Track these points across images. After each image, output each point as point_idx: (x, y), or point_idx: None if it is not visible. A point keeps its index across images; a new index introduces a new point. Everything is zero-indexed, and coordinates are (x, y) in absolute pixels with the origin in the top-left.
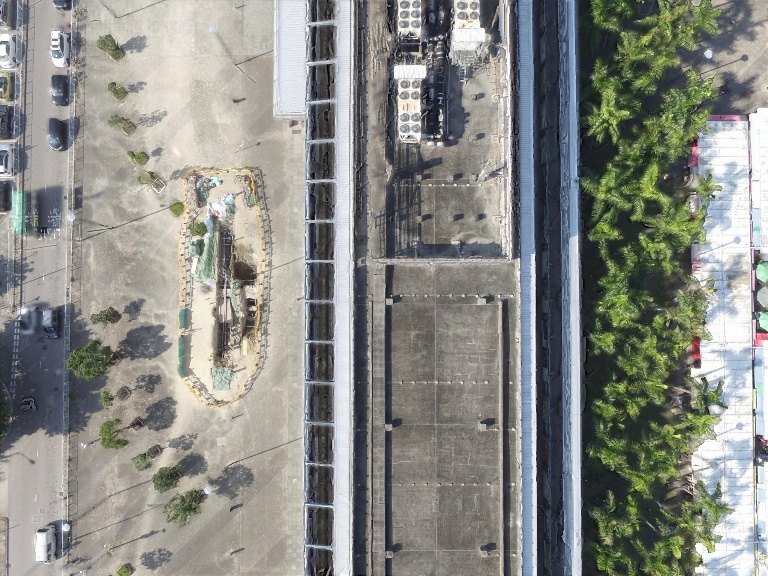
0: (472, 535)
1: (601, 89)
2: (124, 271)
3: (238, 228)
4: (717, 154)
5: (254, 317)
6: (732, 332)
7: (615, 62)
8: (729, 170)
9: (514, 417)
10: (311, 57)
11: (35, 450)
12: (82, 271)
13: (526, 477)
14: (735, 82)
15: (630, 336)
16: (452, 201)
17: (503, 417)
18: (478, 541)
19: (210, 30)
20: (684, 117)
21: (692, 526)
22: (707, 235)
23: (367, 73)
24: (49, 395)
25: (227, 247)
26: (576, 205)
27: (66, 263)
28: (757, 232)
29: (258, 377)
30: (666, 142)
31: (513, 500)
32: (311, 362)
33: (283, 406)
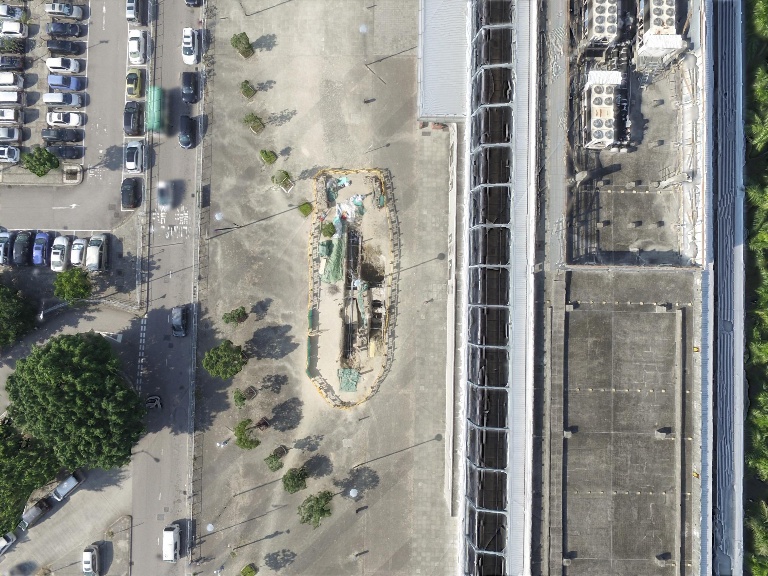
0: (647, 544)
1: (763, 97)
2: (251, 270)
3: (367, 229)
4: None
5: (381, 319)
6: None
7: None
8: None
9: (690, 426)
10: (475, 60)
11: (160, 448)
12: (209, 270)
13: (701, 487)
14: None
15: None
16: (630, 208)
17: (680, 426)
18: (653, 550)
19: (360, 30)
20: None
21: None
22: None
23: (546, 77)
24: (174, 393)
25: (354, 248)
26: (741, 214)
27: (193, 261)
28: None
29: (385, 379)
30: None
31: (688, 510)
32: None
33: (410, 409)
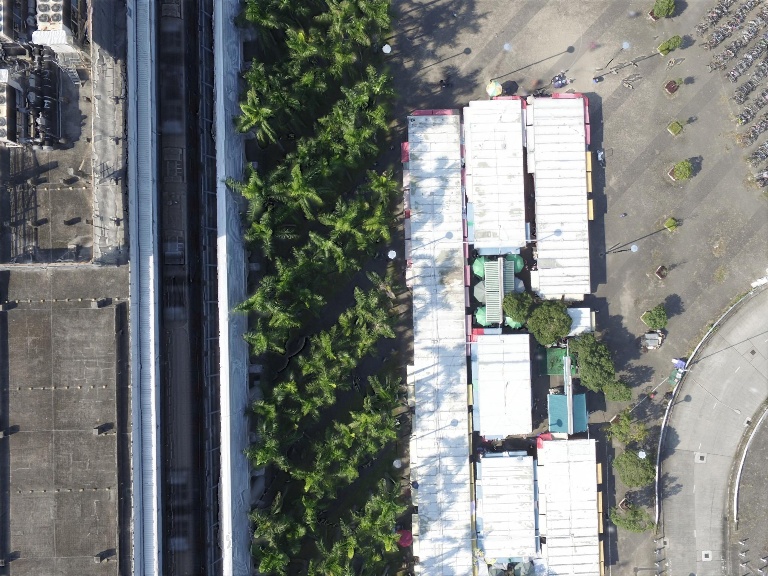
0: (91, 541)
1: None
2: None
3: None
4: (428, 149)
5: None
6: (445, 328)
7: (289, 59)
8: (440, 165)
9: None
10: None
11: None
12: None
13: (147, 481)
14: (458, 76)
15: (314, 335)
16: (69, 205)
17: (121, 421)
18: (97, 547)
19: None
20: (354, 113)
21: (370, 525)
22: (419, 231)
23: None
24: None
25: None
26: (223, 205)
27: None
28: (471, 226)
29: None
30: None
31: None
32: None
33: None
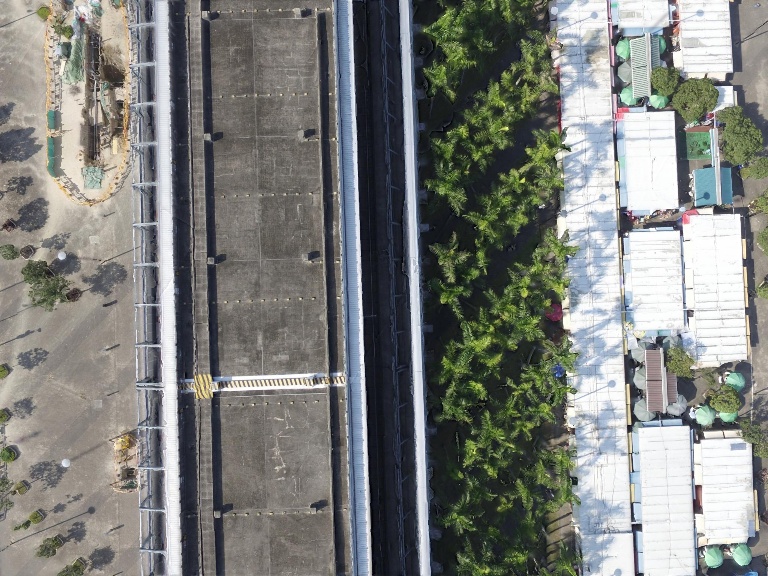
0: (295, 244)
1: None
2: None
3: (105, 30)
4: None
5: None
6: (592, 105)
7: None
8: None
9: (334, 127)
10: None
11: None
12: None
13: (348, 186)
14: None
15: (477, 92)
16: None
17: (323, 127)
18: (301, 249)
19: None
20: None
21: (541, 270)
22: (564, 11)
23: None
24: None
25: (96, 51)
26: None
27: None
28: (615, 8)
29: (129, 175)
30: None
31: (335, 209)
32: (149, 109)
33: None
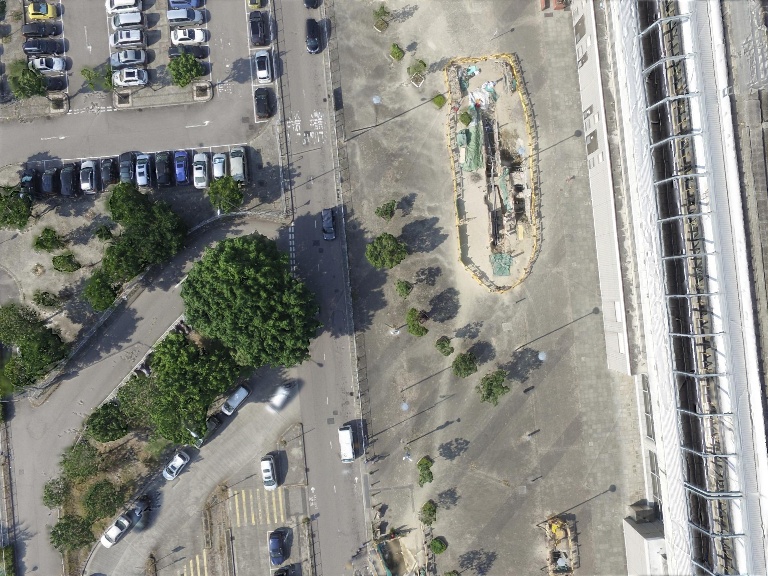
0: None
1: None
2: (392, 167)
3: (501, 115)
4: None
5: (525, 202)
6: None
7: None
8: None
9: None
10: None
11: (322, 353)
12: (350, 171)
13: None
14: None
15: None
16: None
17: None
18: None
19: None
20: None
21: None
22: None
23: None
24: (330, 297)
25: (490, 136)
26: None
27: (333, 165)
28: None
29: (537, 260)
30: None
31: None
32: None
33: (564, 286)
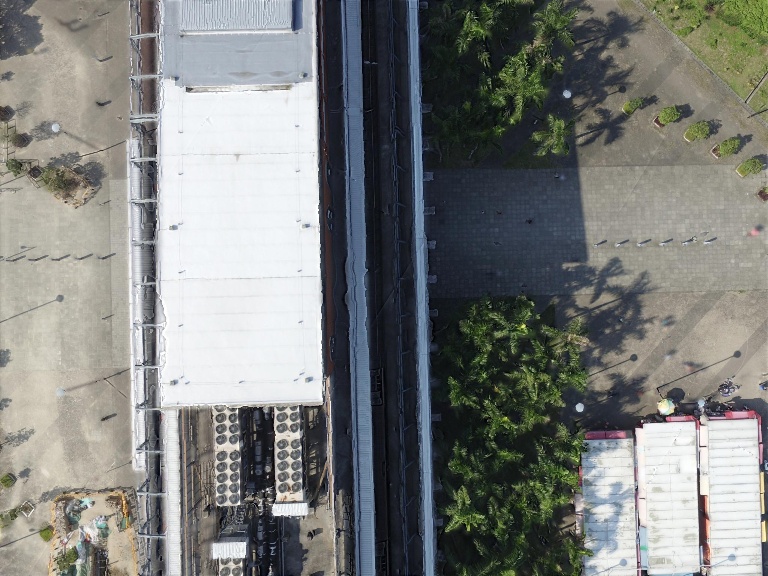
0: None
1: (461, 471)
2: None
3: (112, 551)
4: (602, 474)
5: None
6: None
7: (482, 423)
8: (614, 490)
9: None
10: (153, 455)
11: None
12: None
13: None
14: (624, 383)
15: None
16: None
17: None
18: None
19: (57, 394)
20: (552, 484)
21: None
22: (592, 558)
23: (199, 509)
24: None
25: (102, 569)
26: None
27: None
28: (644, 551)
29: None
30: (538, 499)
31: None
32: None
33: None
